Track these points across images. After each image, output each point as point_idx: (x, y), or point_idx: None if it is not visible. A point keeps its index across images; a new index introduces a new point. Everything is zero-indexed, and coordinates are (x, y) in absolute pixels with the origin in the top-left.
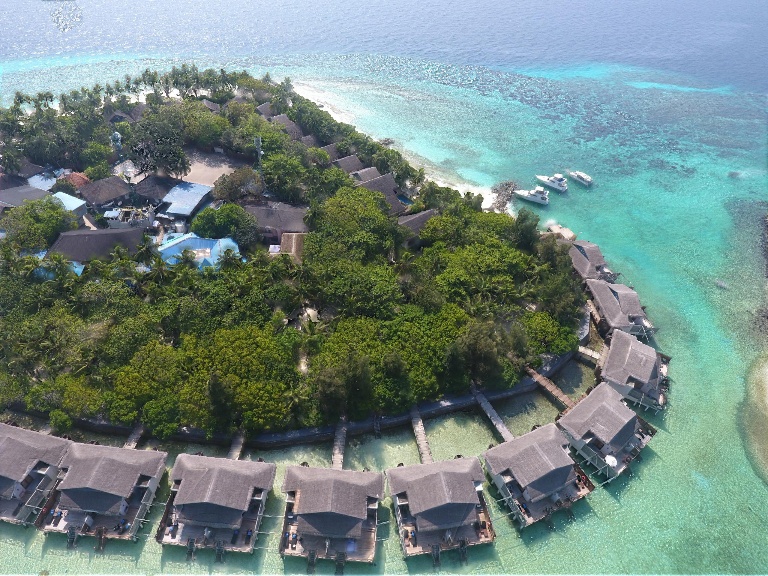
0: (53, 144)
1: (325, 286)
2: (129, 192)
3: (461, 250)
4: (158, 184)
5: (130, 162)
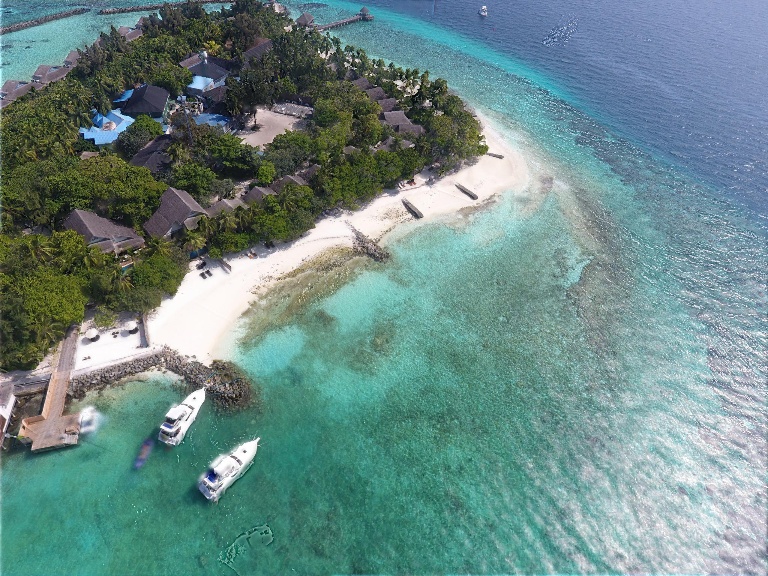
0: (253, 59)
1: (1, 164)
2: (216, 101)
3: (3, 250)
4: (217, 106)
5: (297, 107)
